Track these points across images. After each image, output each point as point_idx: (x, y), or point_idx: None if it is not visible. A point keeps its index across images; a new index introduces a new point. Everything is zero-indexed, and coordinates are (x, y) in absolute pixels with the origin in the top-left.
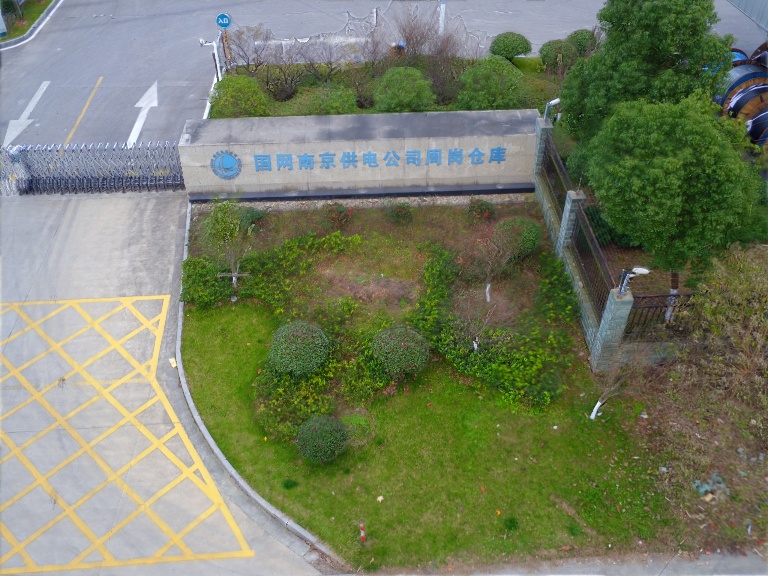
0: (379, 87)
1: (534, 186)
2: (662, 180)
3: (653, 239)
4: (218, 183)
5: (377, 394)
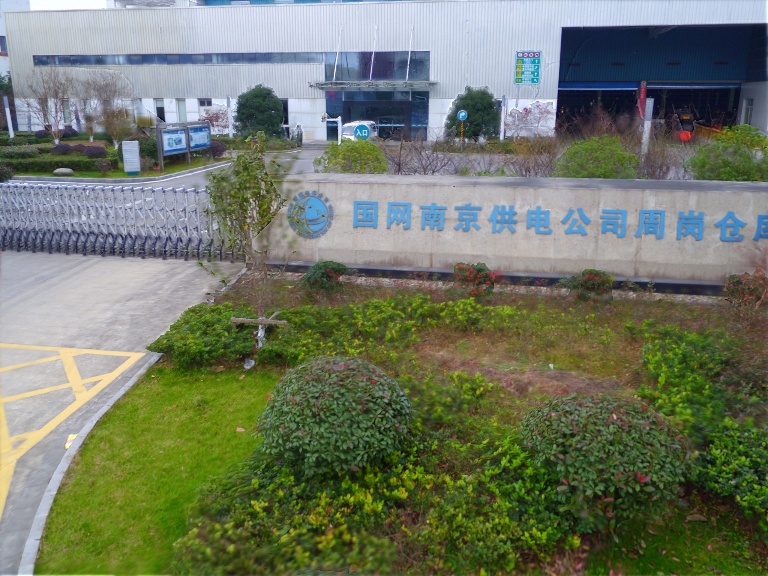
0: (557, 163)
1: None
2: None
3: None
4: (294, 243)
5: (526, 572)
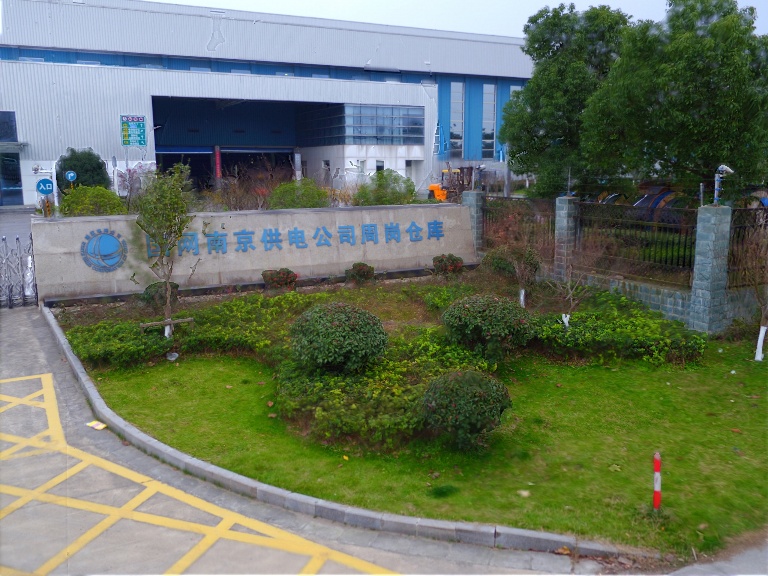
0: (272, 201)
1: (479, 262)
2: (734, 30)
3: (719, 140)
4: (90, 278)
5: None
